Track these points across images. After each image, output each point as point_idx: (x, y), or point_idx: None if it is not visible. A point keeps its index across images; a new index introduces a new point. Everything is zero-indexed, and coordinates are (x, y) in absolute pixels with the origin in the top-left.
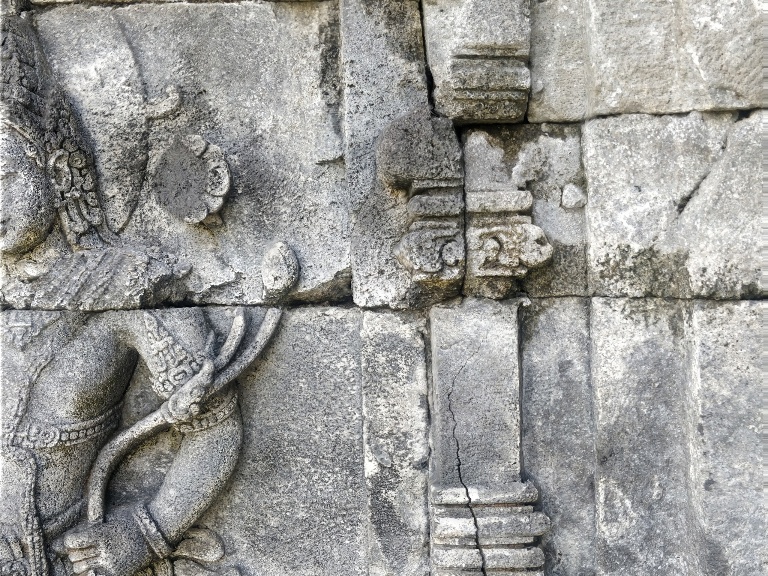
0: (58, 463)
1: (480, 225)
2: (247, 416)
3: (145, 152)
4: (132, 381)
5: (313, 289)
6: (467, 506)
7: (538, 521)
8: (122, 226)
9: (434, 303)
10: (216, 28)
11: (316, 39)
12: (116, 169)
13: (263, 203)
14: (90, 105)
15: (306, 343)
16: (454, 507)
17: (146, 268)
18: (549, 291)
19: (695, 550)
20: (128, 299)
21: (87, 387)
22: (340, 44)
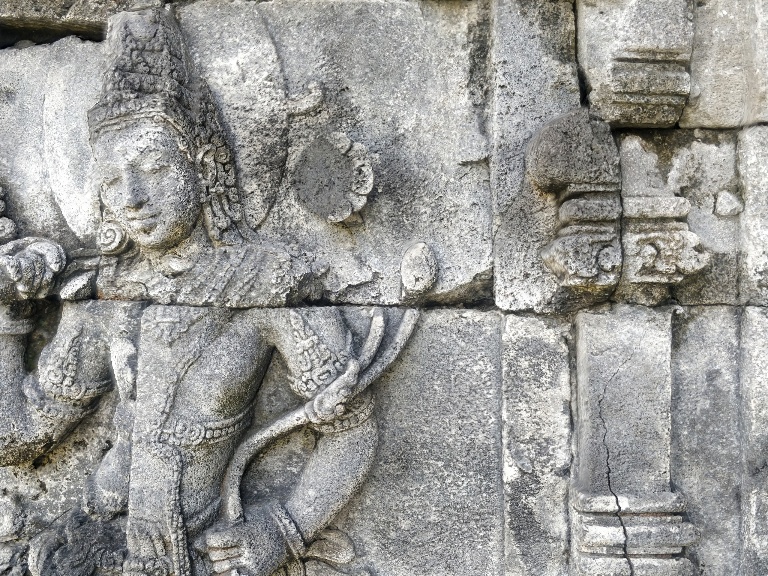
0: (201, 461)
1: (637, 231)
2: (380, 417)
3: (285, 148)
4: (265, 379)
5: (451, 291)
6: (615, 514)
7: (688, 532)
8: (260, 222)
9: (580, 308)
10: (361, 25)
11: (464, 38)
12: (255, 165)
13: (403, 203)
14: (231, 100)
15: (442, 345)
16: (603, 515)
17: (291, 266)
18: (699, 299)
19: None
20: (274, 297)
21: (232, 385)
22: (490, 44)
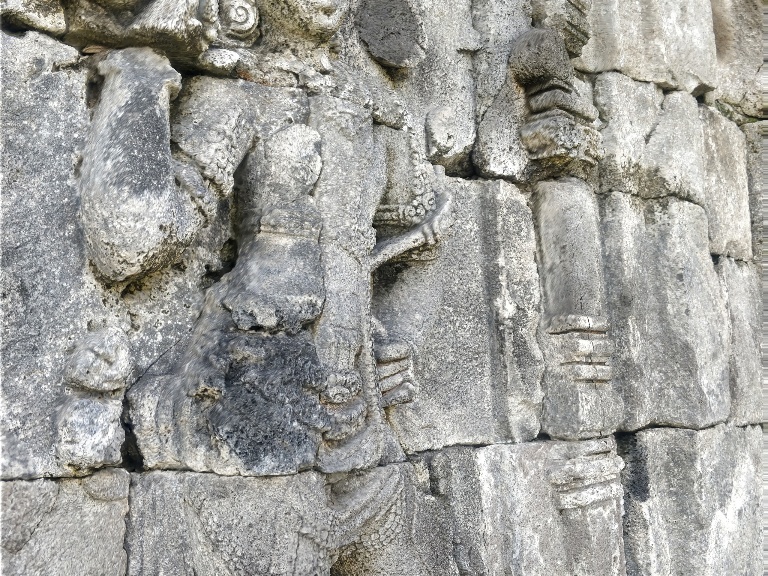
0: None
1: (581, 123)
2: None
3: None
4: None
5: (450, 157)
6: (585, 332)
7: None
8: None
9: (538, 180)
10: None
11: None
12: None
13: (425, 71)
14: None
15: None
16: (581, 332)
17: None
18: None
19: (674, 360)
20: (400, 117)
21: None
22: None
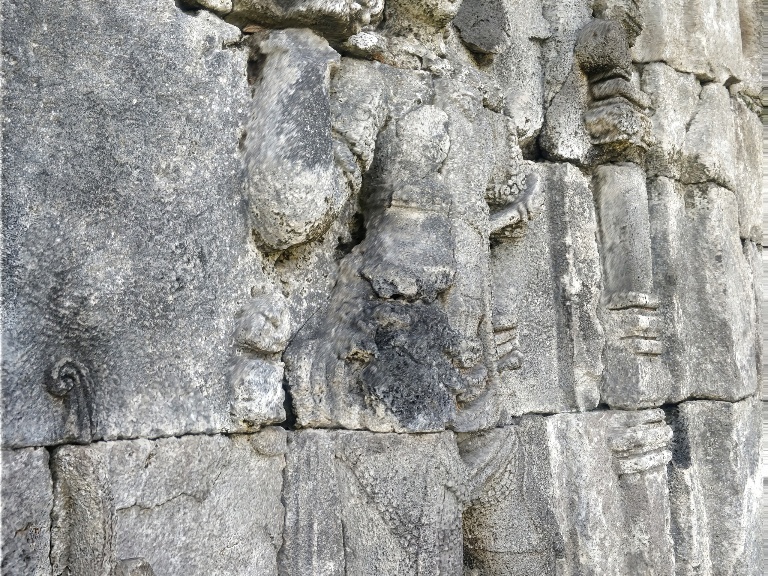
0: None
1: (638, 110)
2: None
3: None
4: None
5: (522, 140)
6: (641, 308)
7: None
8: None
9: (598, 164)
10: None
11: None
12: None
13: None
14: None
15: None
16: (639, 308)
17: None
18: None
19: (712, 337)
20: (500, 101)
21: None
22: None
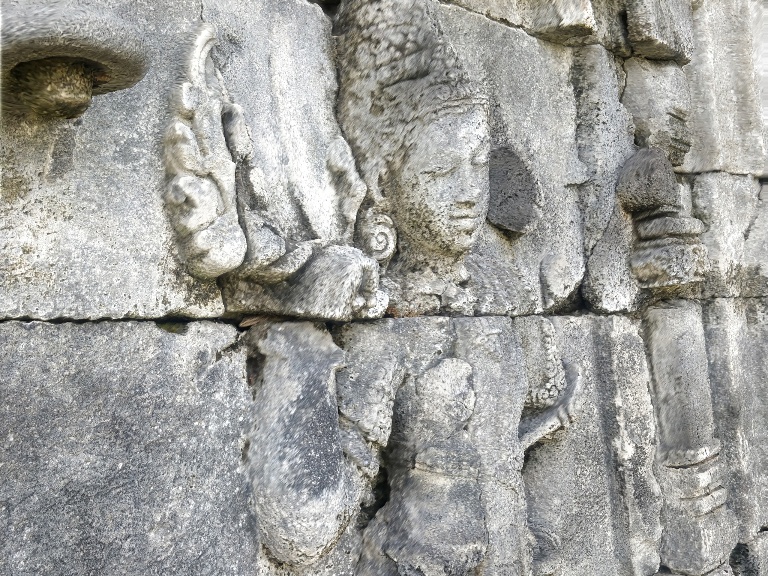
0: None
1: (689, 243)
2: None
3: None
4: None
5: None
6: (702, 462)
7: None
8: None
9: (647, 306)
10: (505, 48)
11: (566, 77)
12: None
13: None
14: None
15: None
16: (699, 464)
17: None
18: None
19: None
20: (532, 304)
21: None
22: (586, 86)
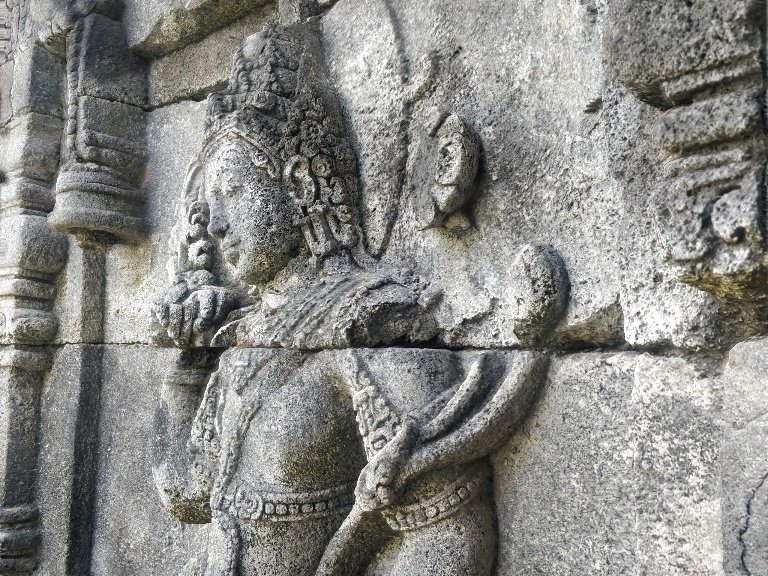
0: (266, 542)
1: None
2: (505, 523)
3: (403, 147)
4: None
5: (590, 320)
6: None
7: None
8: (382, 246)
9: (752, 333)
10: None
11: None
12: (378, 175)
13: (522, 189)
14: (358, 103)
15: (580, 411)
16: None
17: (365, 293)
18: None
19: None
20: (336, 333)
21: (293, 447)
22: None
